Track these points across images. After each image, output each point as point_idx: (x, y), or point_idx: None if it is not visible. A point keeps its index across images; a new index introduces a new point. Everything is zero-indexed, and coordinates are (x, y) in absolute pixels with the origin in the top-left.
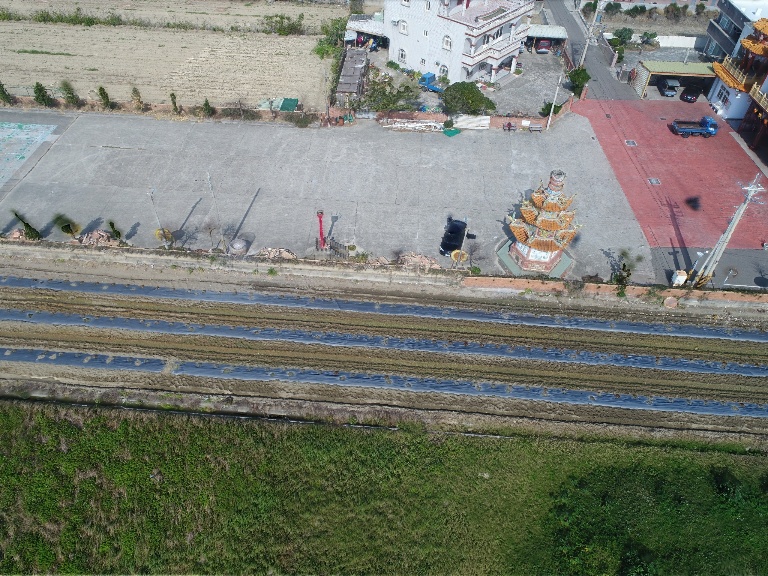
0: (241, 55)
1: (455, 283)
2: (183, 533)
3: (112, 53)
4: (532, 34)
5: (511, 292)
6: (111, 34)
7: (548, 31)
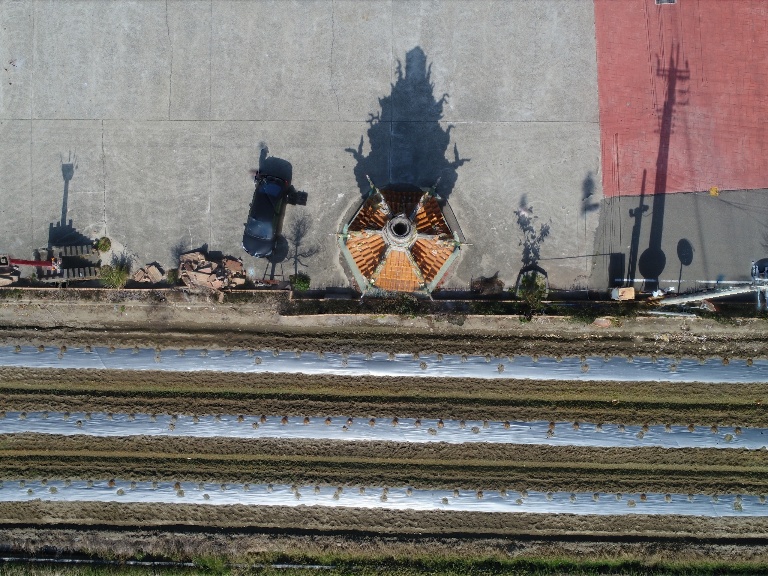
0: None
1: None
2: None
3: None
4: None
5: None
6: None
7: None
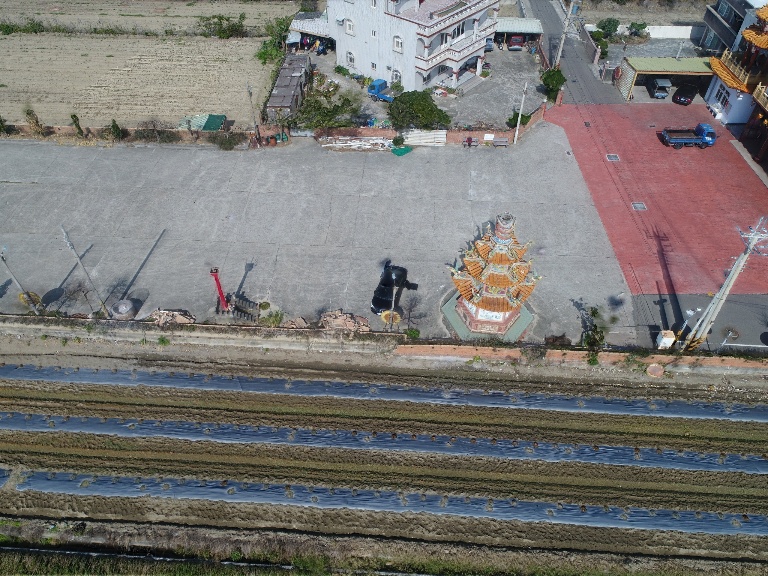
0: (173, 63)
1: (387, 351)
2: None
3: (27, 65)
4: (502, 29)
5: (456, 360)
6: (30, 43)
7: (520, 25)
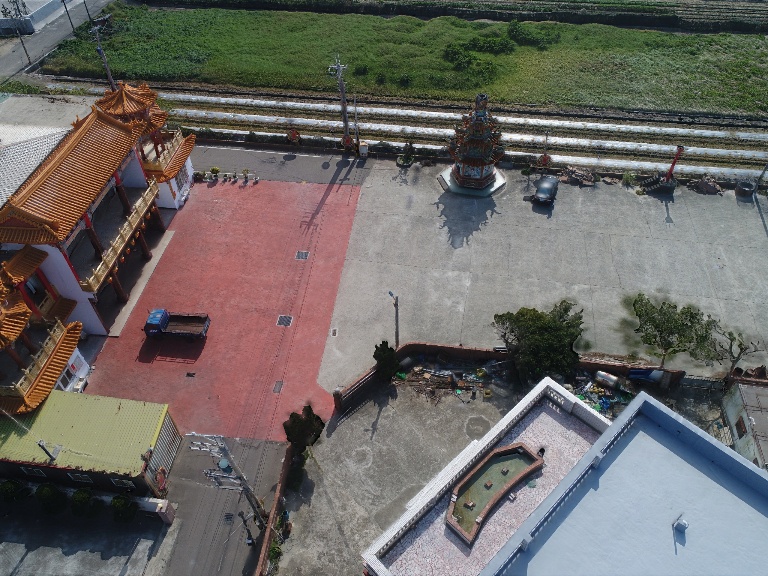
0: None
1: None
2: None
3: None
4: None
5: None
6: None
7: None
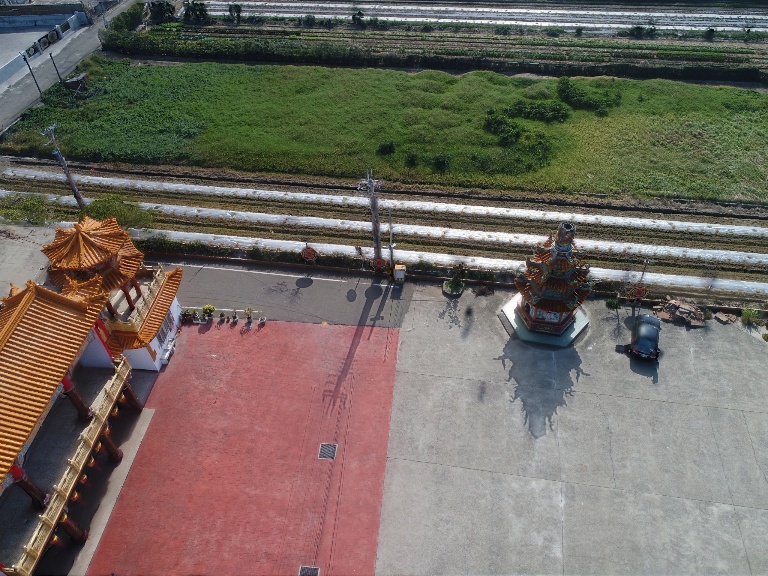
0: None
1: None
2: (765, 158)
3: None
4: None
5: None
6: None
7: None
